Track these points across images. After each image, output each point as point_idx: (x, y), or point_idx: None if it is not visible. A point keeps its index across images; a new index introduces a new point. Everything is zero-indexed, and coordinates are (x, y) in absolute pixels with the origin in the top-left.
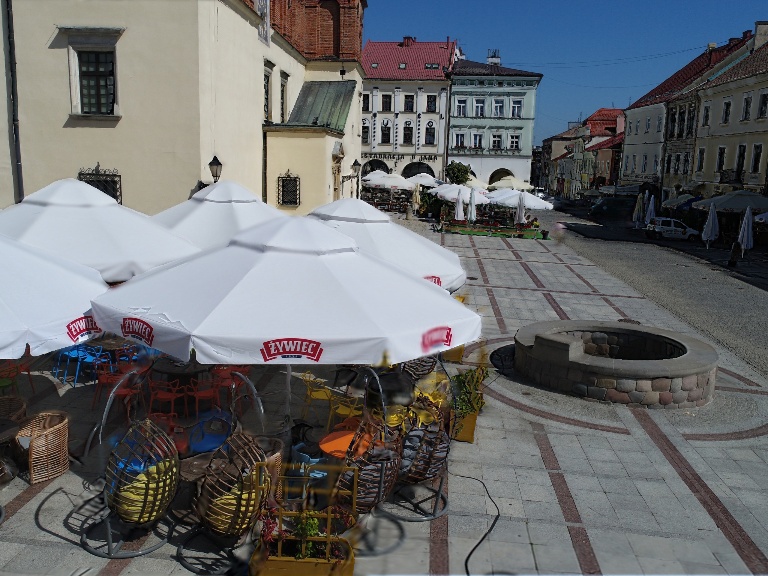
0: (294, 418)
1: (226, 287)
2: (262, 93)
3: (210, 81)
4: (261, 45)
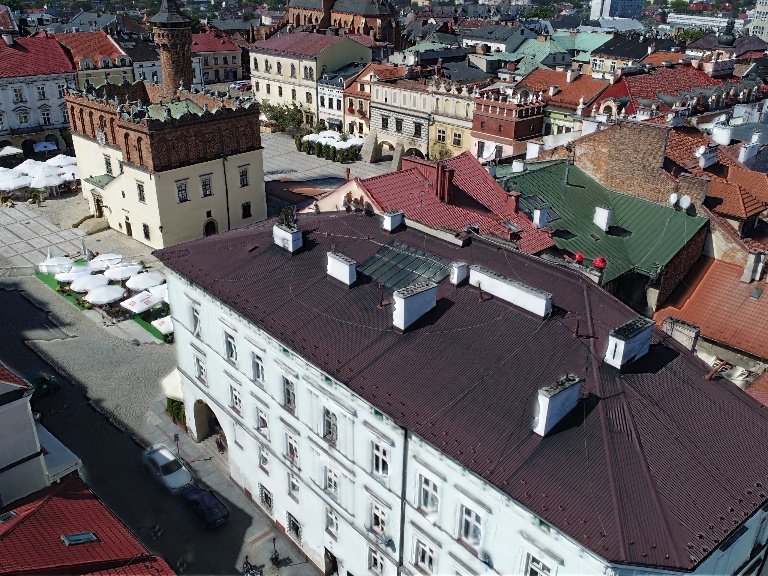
0: None
1: None
2: None
3: None
4: (101, 149)
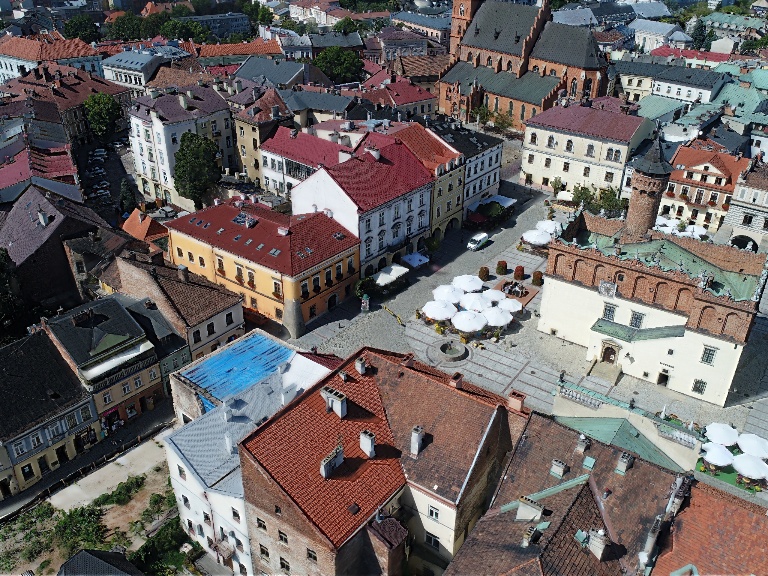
0: (447, 323)
1: None
2: (601, 310)
3: (550, 296)
4: (602, 297)
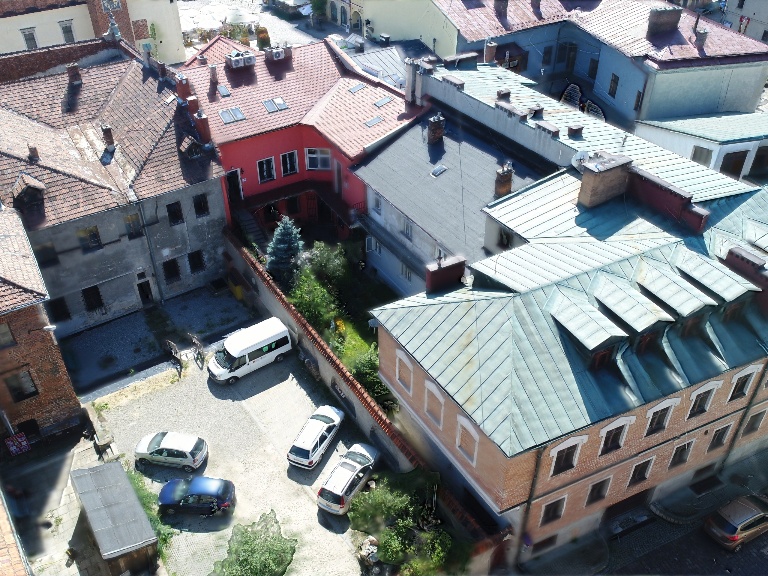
0: None
1: (226, 5)
2: None
3: None
4: None
